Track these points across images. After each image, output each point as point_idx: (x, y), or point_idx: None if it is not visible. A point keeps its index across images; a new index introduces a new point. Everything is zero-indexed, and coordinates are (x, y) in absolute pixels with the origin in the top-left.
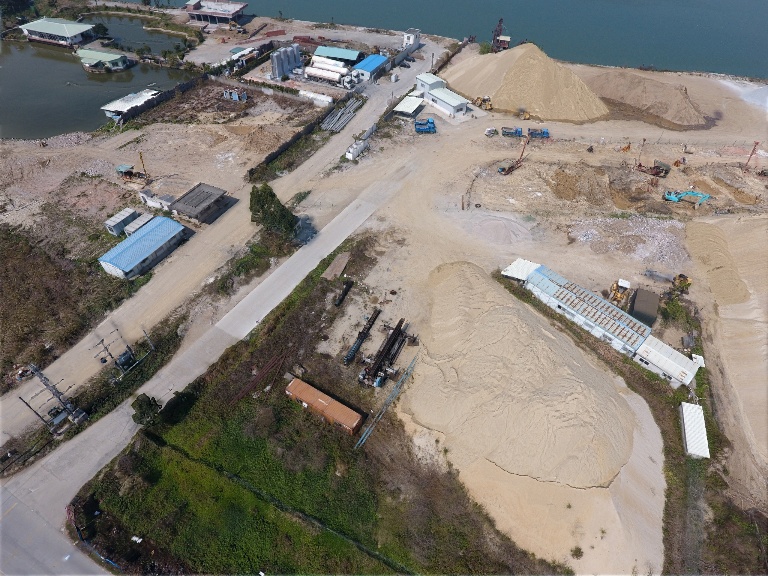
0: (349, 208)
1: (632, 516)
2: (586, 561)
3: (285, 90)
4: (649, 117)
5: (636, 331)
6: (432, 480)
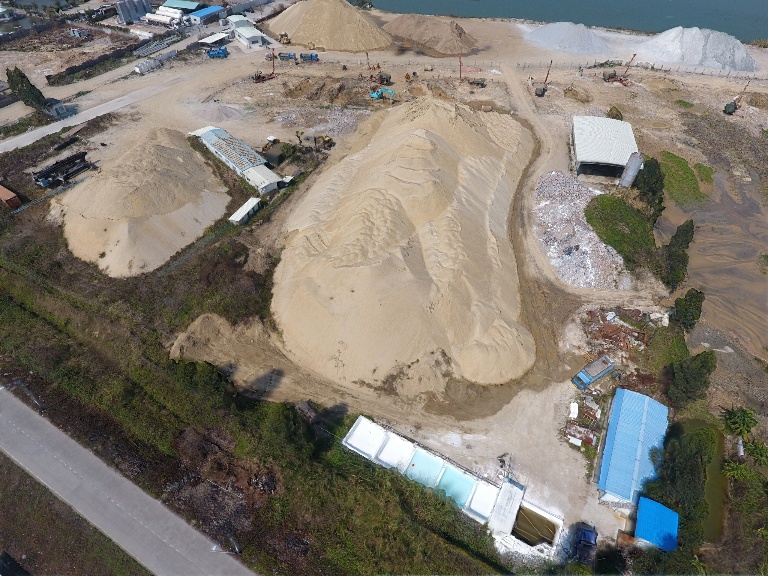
0: (113, 101)
1: (145, 237)
2: (106, 259)
3: (123, 30)
4: (422, 49)
5: (251, 161)
6: (46, 229)
